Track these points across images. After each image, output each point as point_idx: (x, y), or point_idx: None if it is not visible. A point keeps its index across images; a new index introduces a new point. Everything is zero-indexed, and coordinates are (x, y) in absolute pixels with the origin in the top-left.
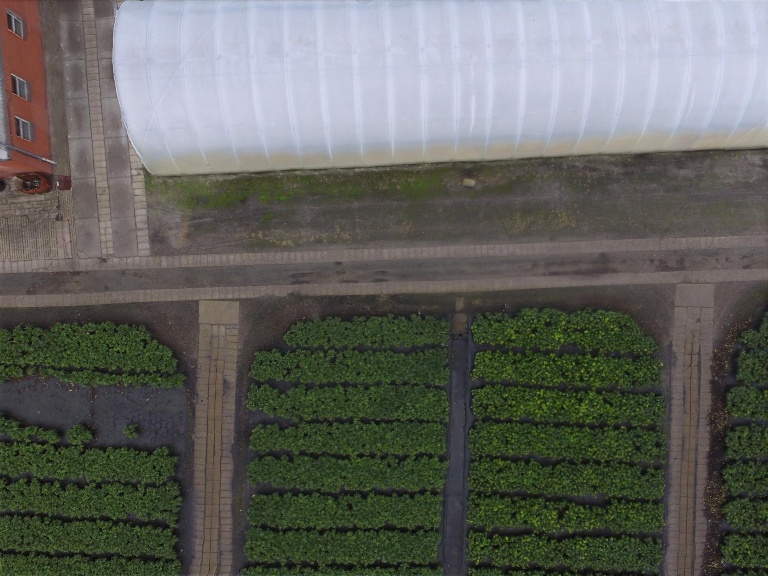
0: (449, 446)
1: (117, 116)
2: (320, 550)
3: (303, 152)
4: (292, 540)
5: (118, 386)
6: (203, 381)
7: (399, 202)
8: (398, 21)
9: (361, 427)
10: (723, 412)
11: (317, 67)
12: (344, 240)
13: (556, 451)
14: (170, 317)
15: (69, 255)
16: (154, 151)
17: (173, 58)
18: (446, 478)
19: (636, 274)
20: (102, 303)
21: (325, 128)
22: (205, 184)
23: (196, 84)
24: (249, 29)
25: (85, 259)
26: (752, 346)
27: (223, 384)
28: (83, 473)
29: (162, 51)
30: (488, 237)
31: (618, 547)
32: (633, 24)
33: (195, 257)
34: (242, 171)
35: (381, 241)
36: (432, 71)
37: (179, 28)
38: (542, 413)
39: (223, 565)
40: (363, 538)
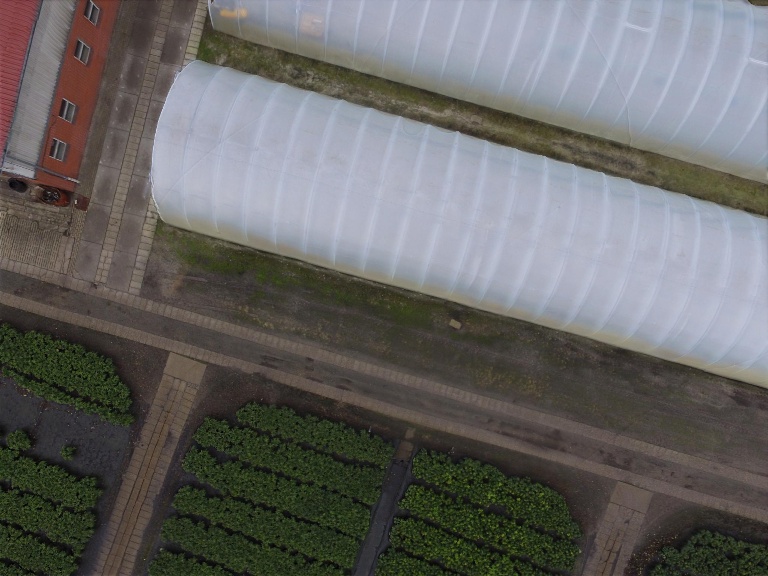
0: (358, 561)
1: (151, 157)
2: None
3: (309, 251)
4: None
5: (70, 406)
6: (149, 427)
7: (385, 321)
8: (433, 167)
9: (281, 519)
10: None
11: (344, 186)
12: (322, 340)
13: None
14: (138, 358)
15: (65, 271)
16: (172, 208)
17: (215, 136)
18: None
19: (583, 460)
20: (80, 325)
21: (335, 240)
22: (211, 246)
23: (228, 166)
24: (294, 131)
25: (78, 279)
26: (669, 563)
27: (167, 436)
28: (10, 478)
29: (207, 126)
30: (457, 380)
31: None
32: (650, 240)
33: (180, 311)
34: (249, 246)
35: (356, 352)
36: (449, 224)
37: (230, 109)
38: (453, 561)
39: None
40: None
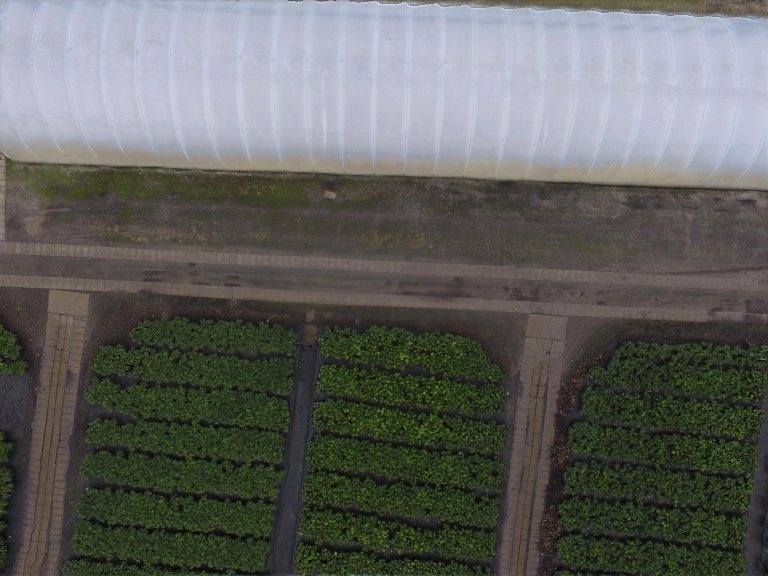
0: (289, 456)
1: None
2: (147, 549)
3: (159, 151)
4: (120, 536)
5: None
6: (47, 370)
7: (258, 208)
8: (253, 28)
9: (199, 430)
10: (565, 446)
11: (167, 67)
12: (199, 242)
13: (392, 471)
14: (19, 303)
15: None
16: (8, 137)
17: (23, 46)
18: (282, 488)
19: (489, 301)
20: None
21: (176, 129)
22: (66, 174)
23: (45, 74)
24: (103, 24)
25: None
26: (598, 383)
27: (66, 375)
28: None
29: (13, 39)
30: (344, 251)
31: (446, 572)
32: (488, 51)
33: (49, 246)
34: (103, 164)
35: (236, 246)
36: (282, 81)
37: (34, 17)
38: (381, 432)
39: (50, 555)
40: (191, 541)
